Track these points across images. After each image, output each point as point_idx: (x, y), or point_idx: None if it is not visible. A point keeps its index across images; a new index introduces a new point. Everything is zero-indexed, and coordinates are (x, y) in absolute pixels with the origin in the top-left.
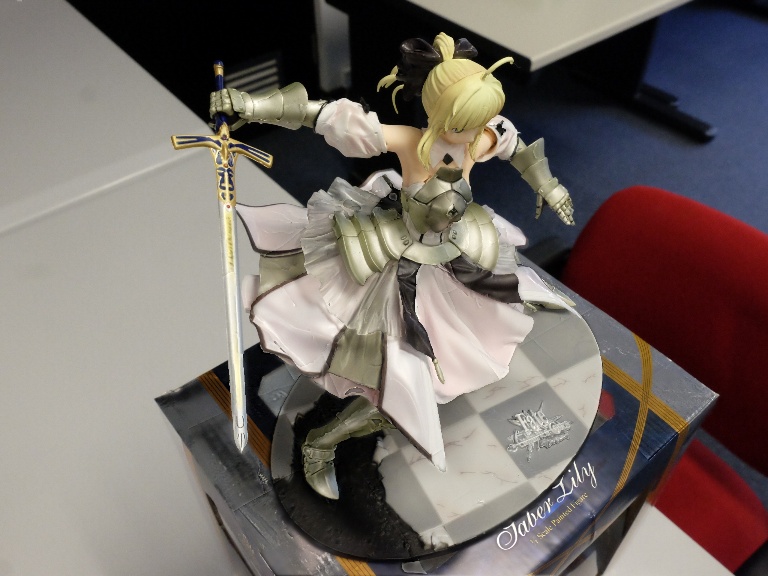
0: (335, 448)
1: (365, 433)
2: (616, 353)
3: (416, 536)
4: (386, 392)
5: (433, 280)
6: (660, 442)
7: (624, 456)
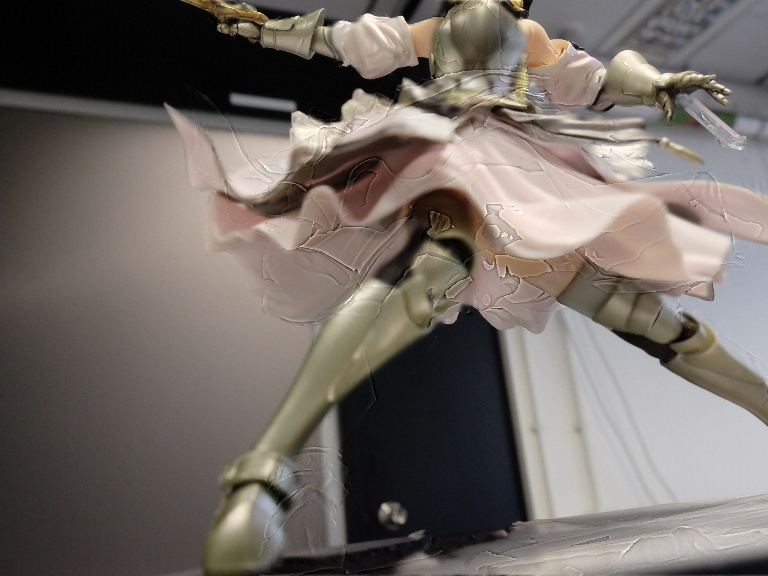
0: (343, 457)
1: (406, 352)
2: None
3: (610, 565)
4: (402, 95)
5: None
6: None
7: None
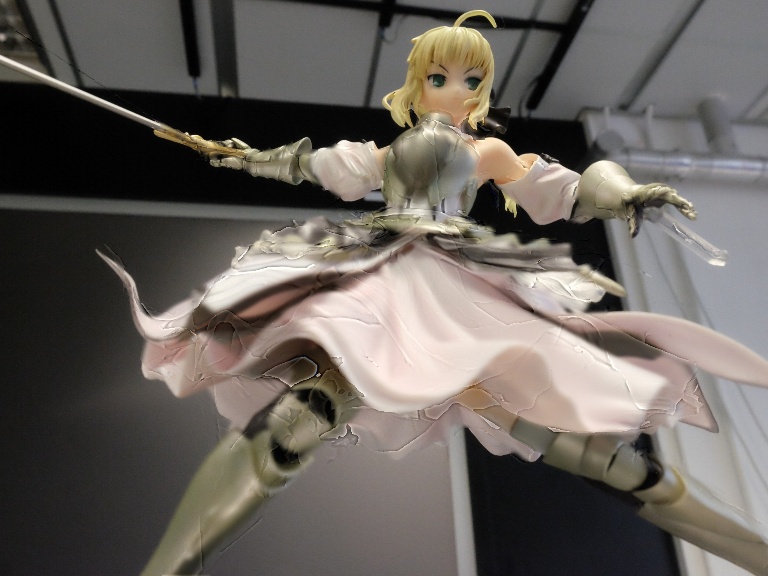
0: None
1: (232, 518)
2: None
3: None
4: None
5: (433, 263)
6: None
7: None
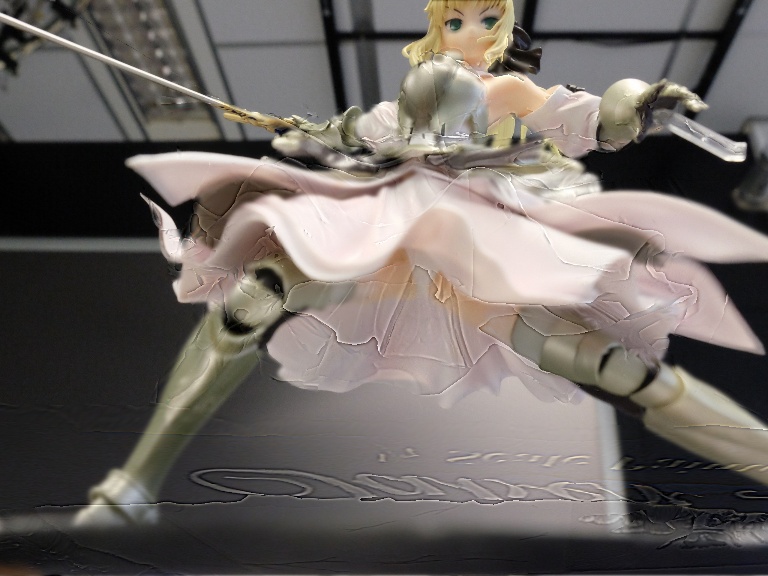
0: None
1: None
2: None
3: None
4: None
5: None
6: None
7: None
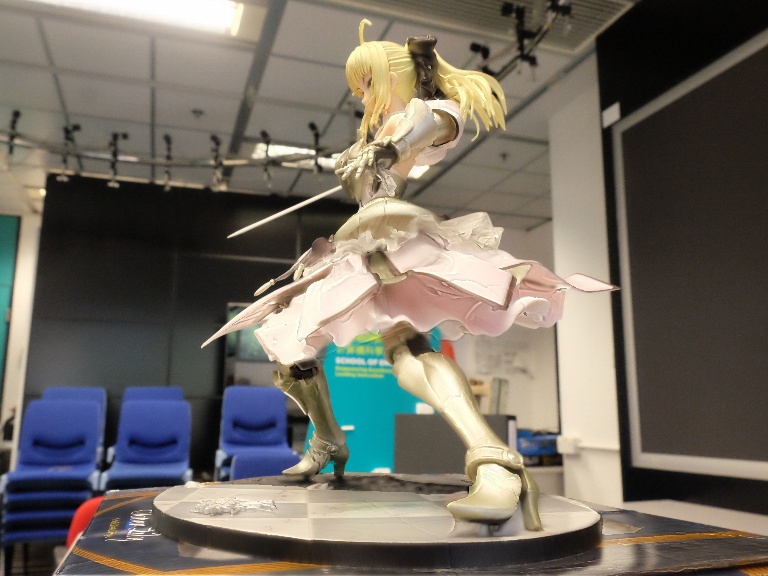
0: (316, 437)
1: None
2: (307, 574)
3: None
4: None
5: None
6: (67, 575)
7: (105, 554)
